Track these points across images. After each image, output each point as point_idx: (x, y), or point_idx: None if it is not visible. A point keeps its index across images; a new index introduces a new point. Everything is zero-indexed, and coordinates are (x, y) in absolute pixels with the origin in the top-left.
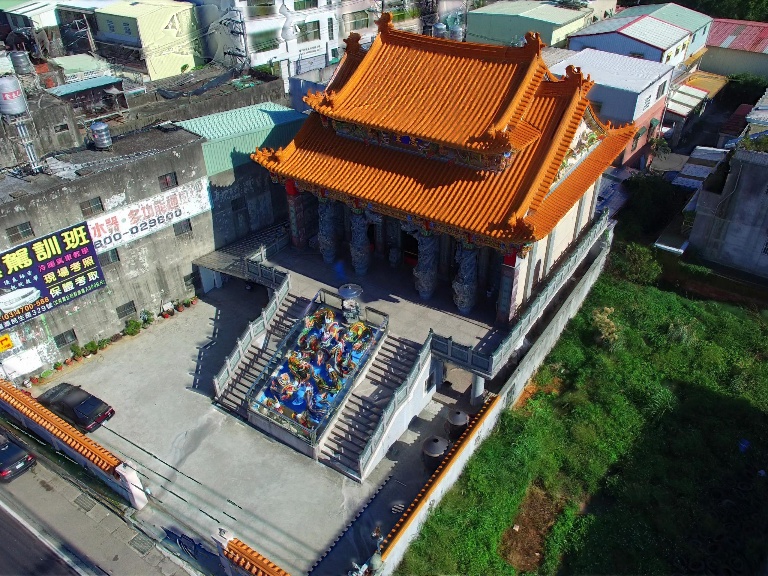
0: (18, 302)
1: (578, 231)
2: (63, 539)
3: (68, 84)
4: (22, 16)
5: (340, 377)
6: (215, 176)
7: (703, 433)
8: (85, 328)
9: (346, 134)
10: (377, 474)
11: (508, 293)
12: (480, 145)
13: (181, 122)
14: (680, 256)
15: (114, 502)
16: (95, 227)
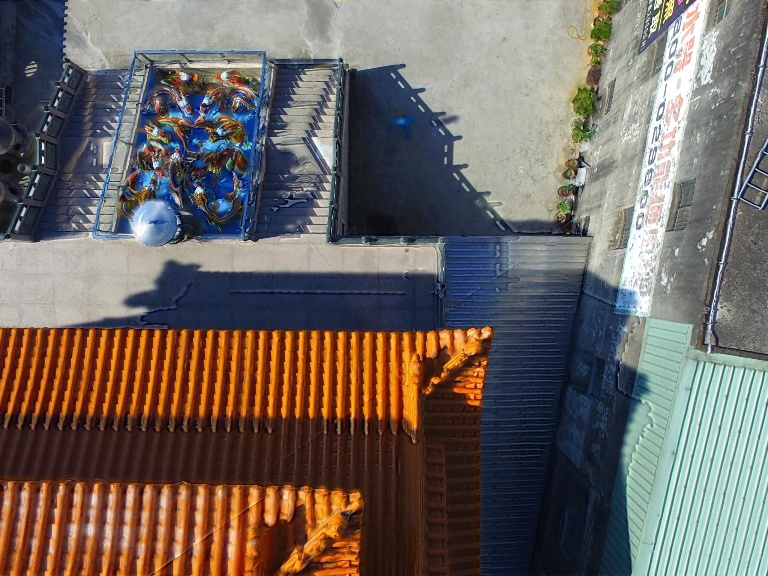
0: None
1: None
2: None
3: None
4: None
5: None
6: None
7: None
8: None
9: None
10: None
11: None
12: None
13: None
14: None
15: None
16: None
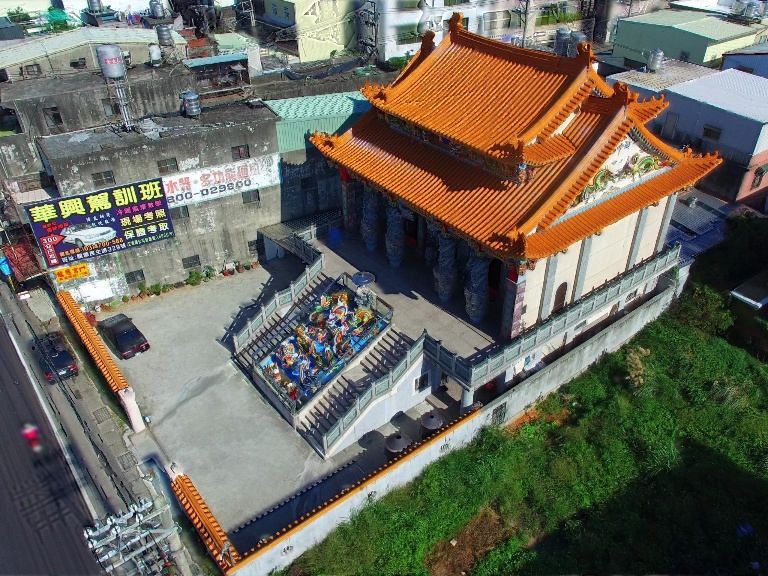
0: (97, 238)
1: (633, 262)
2: (72, 440)
3: (203, 58)
4: None
5: (335, 358)
6: (287, 154)
7: (699, 504)
8: (153, 271)
9: (398, 128)
10: (343, 456)
11: (511, 309)
12: (500, 153)
13: (271, 101)
14: (758, 310)
15: (121, 421)
16: (169, 184)
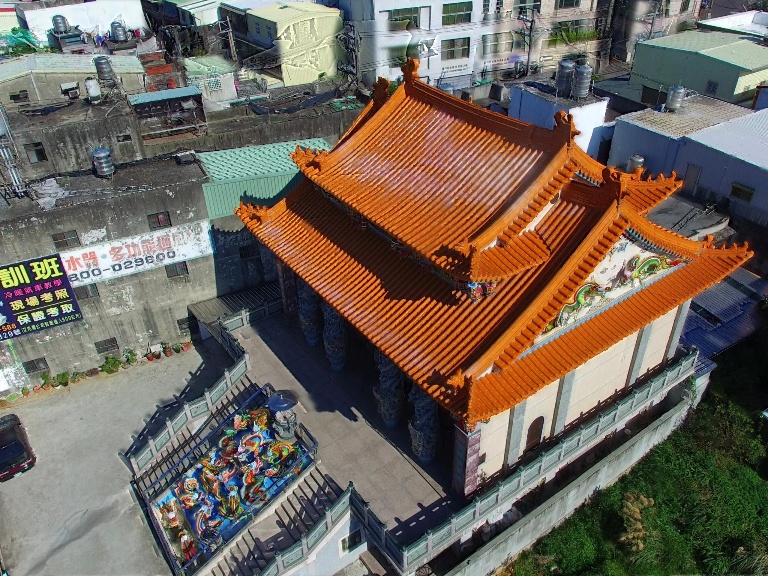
0: None
1: (634, 376)
2: None
3: (152, 92)
4: (189, 12)
5: (243, 504)
6: (219, 220)
7: None
8: (58, 358)
9: None
10: None
11: (462, 462)
12: (447, 262)
13: (207, 153)
14: None
15: None
16: (70, 260)
